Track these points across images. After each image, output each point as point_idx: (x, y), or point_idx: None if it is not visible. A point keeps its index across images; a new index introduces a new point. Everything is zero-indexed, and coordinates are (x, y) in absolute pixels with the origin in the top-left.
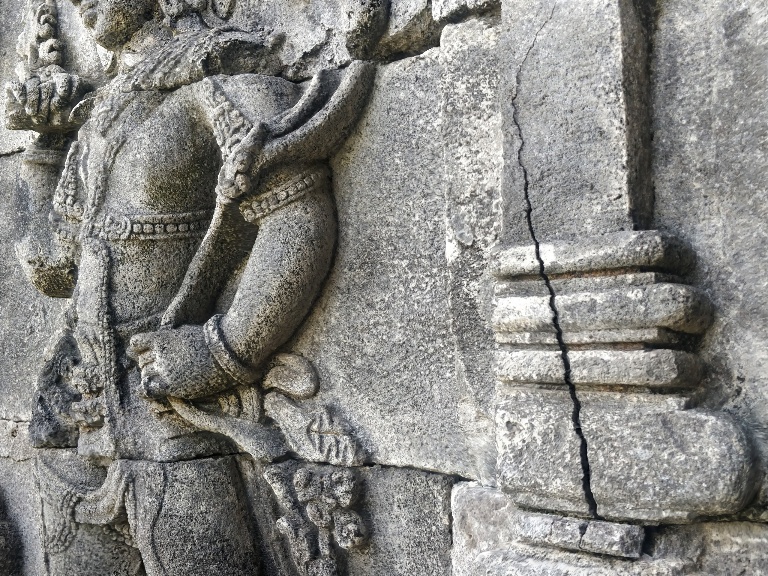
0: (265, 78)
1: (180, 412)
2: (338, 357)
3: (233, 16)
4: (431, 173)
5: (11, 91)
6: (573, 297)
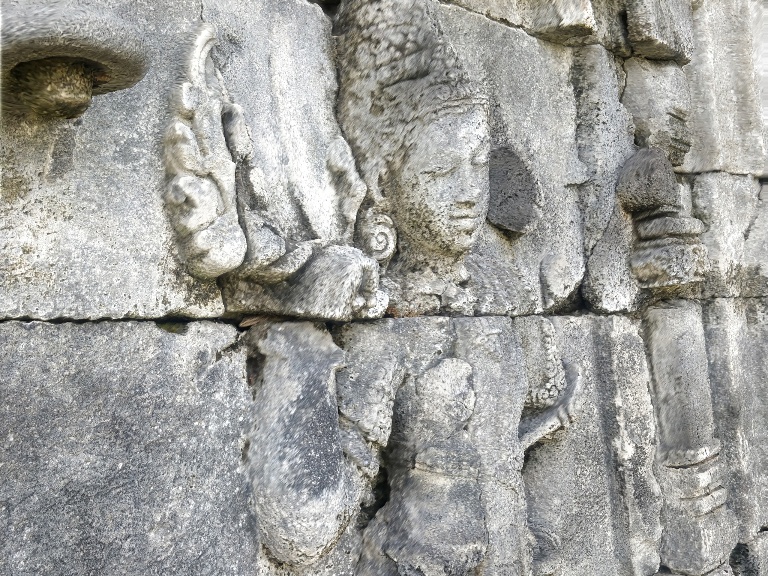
0: None
1: None
2: None
3: None
4: None
5: (367, 270)
6: (712, 470)
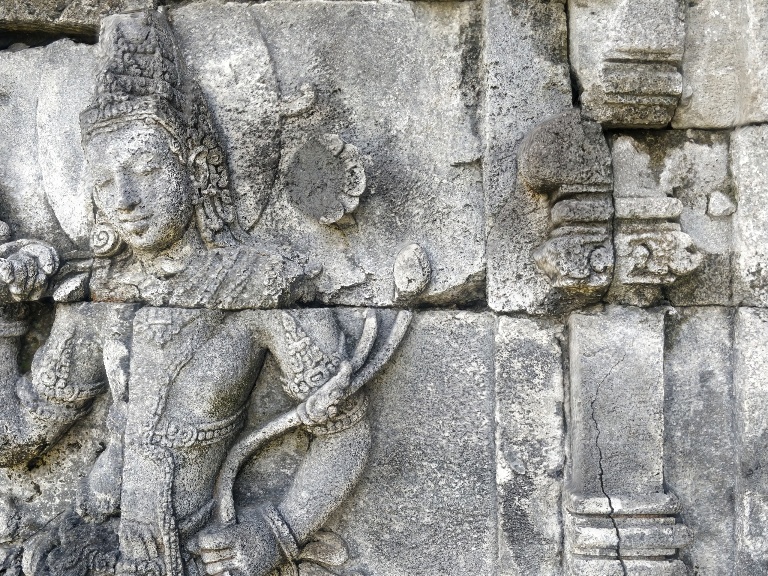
0: (326, 313)
1: None
2: (366, 532)
3: (255, 230)
4: (462, 404)
5: None
6: (630, 531)
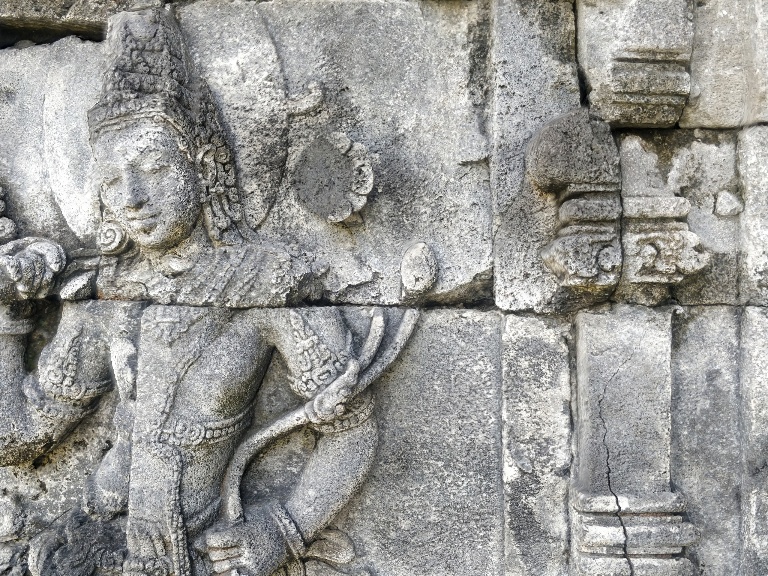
0: (333, 311)
1: None
2: (372, 530)
3: (262, 229)
4: (468, 403)
5: (1, 265)
6: (637, 529)
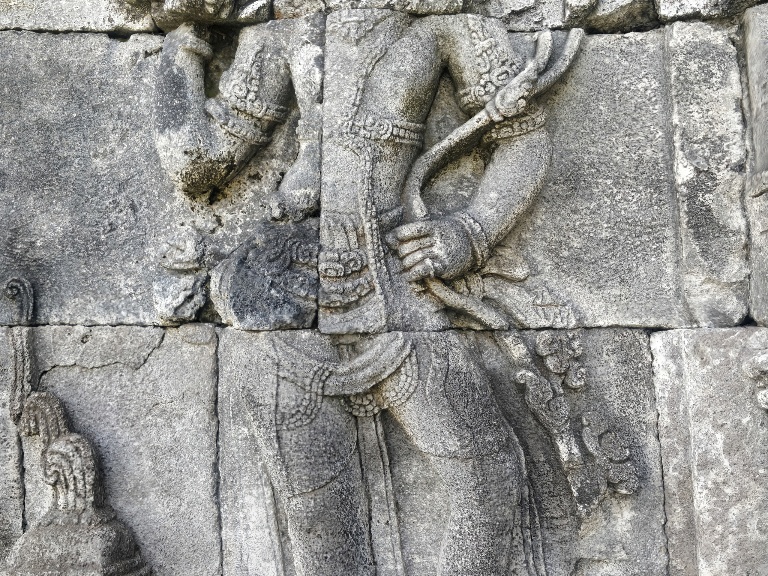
0: (504, 25)
1: (439, 291)
2: (545, 250)
3: None
4: (634, 120)
5: None
6: None
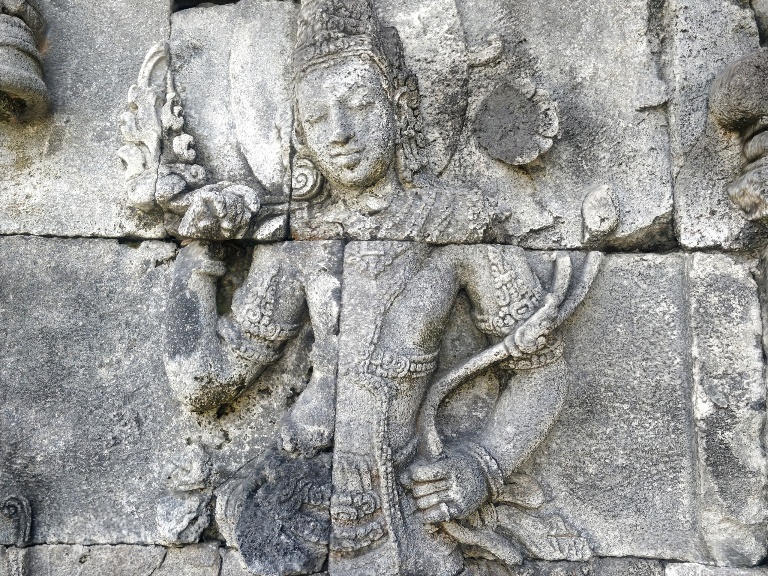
0: (523, 251)
1: (453, 531)
2: (560, 475)
3: (443, 176)
4: (652, 344)
5: (208, 201)
6: None
